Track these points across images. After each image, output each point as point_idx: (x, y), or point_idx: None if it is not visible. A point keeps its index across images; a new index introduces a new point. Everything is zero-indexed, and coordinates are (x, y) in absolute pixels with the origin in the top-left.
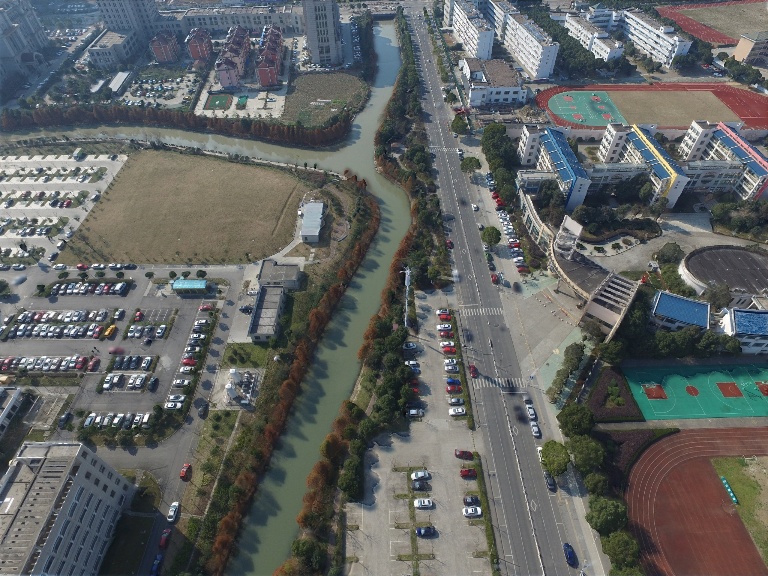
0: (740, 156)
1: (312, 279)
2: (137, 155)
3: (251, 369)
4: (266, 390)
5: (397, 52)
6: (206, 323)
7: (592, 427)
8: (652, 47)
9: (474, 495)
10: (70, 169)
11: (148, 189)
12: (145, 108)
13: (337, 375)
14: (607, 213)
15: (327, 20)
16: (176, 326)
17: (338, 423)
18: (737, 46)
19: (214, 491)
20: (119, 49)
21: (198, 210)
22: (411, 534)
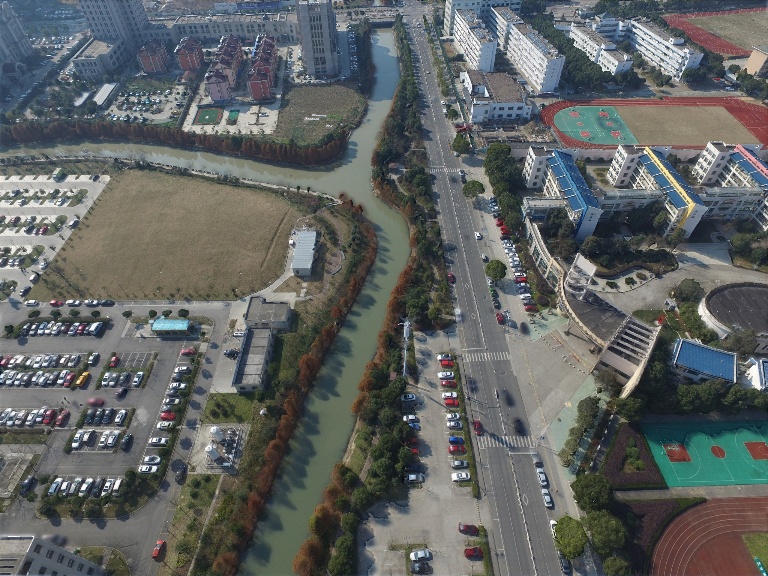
0: (760, 182)
1: (303, 318)
2: (120, 176)
3: (235, 424)
4: (251, 450)
5: (396, 62)
6: (187, 370)
7: (611, 499)
8: (661, 59)
9: None
10: (48, 191)
11: (130, 214)
12: (131, 123)
13: (329, 430)
14: (620, 245)
15: (322, 30)
16: (155, 373)
17: (329, 493)
18: (749, 58)
19: (190, 574)
20: (105, 59)
21: (182, 239)
22: None
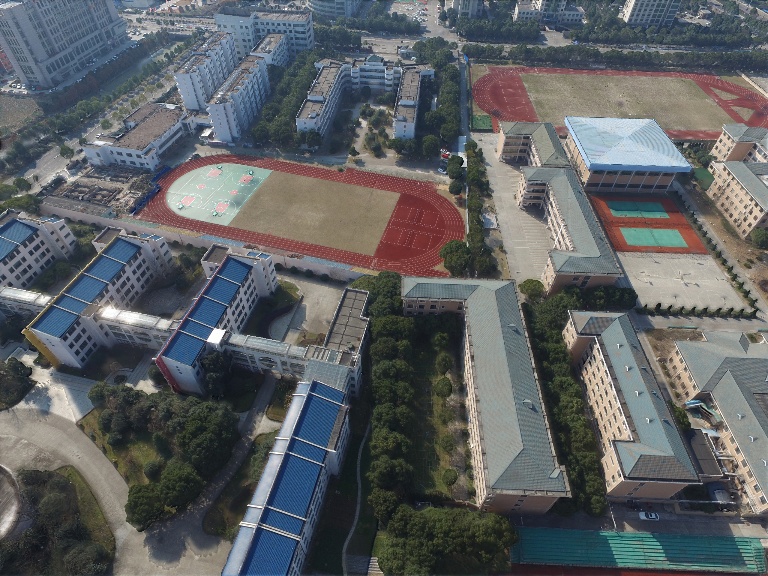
0: None
1: None
2: None
3: None
4: None
5: None
6: None
7: None
8: None
9: None
10: None
11: None
12: None
13: None
14: None
15: (16, 38)
16: None
17: None
18: (499, 136)
19: None
20: None
21: None
22: None
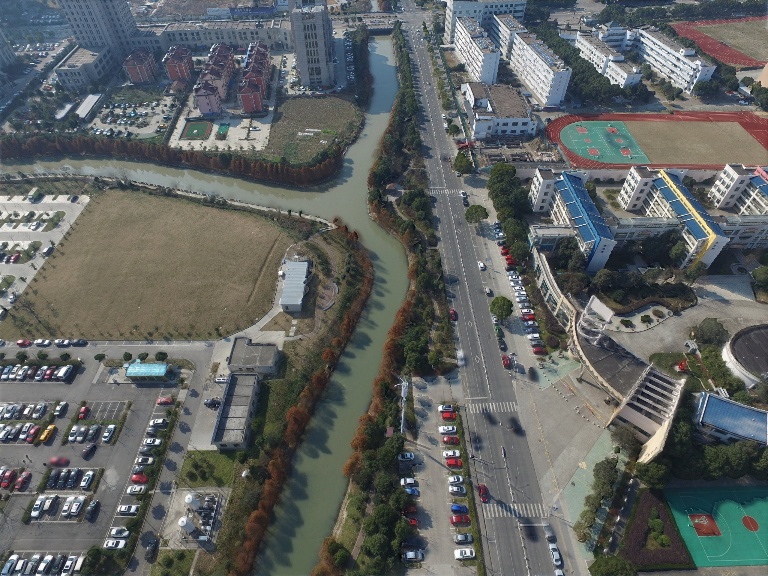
0: None
1: (292, 361)
2: (100, 196)
3: (214, 489)
4: (231, 520)
5: (394, 72)
6: (163, 423)
7: None
8: (671, 70)
9: None
10: (23, 214)
11: (109, 241)
12: (114, 139)
13: (318, 495)
14: (635, 279)
15: (317, 40)
16: (127, 426)
17: None
18: (763, 70)
19: None
20: (90, 69)
21: (164, 269)
22: None
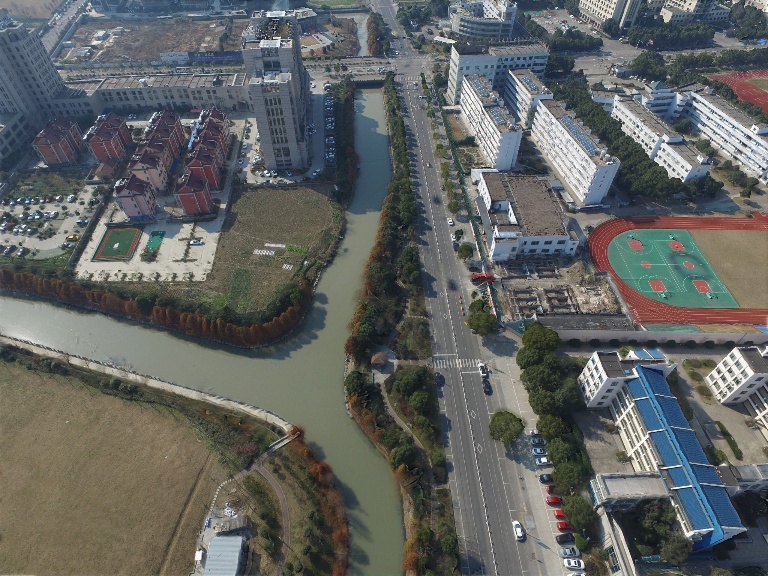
0: None
1: None
2: None
3: None
4: None
5: (385, 145)
6: None
7: None
8: (737, 149)
9: None
10: None
11: None
12: None
13: None
14: None
15: (284, 116)
16: None
17: None
18: None
19: None
20: None
21: (9, 552)
22: None
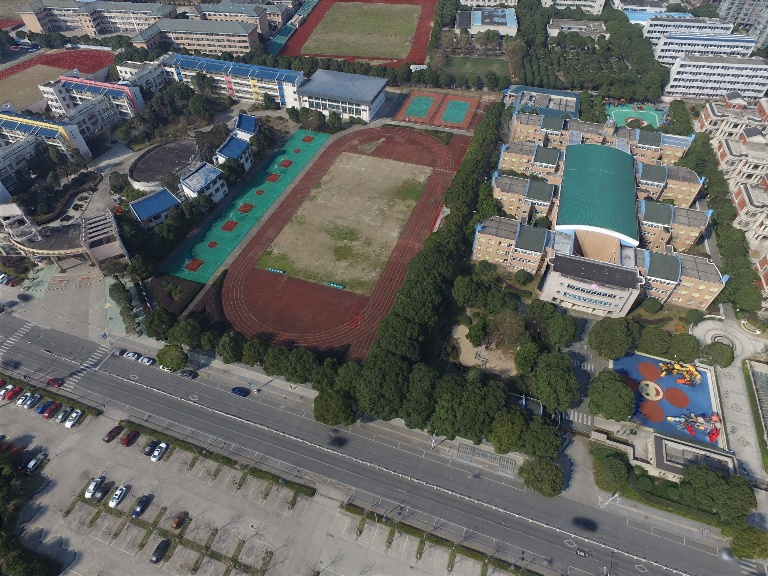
0: (97, 91)
1: None
2: None
3: None
4: None
5: None
6: None
7: None
8: None
9: (149, 443)
10: None
11: None
12: None
13: None
14: (40, 189)
15: None
16: None
17: None
18: (25, 22)
19: None
20: None
21: None
22: (132, 523)
